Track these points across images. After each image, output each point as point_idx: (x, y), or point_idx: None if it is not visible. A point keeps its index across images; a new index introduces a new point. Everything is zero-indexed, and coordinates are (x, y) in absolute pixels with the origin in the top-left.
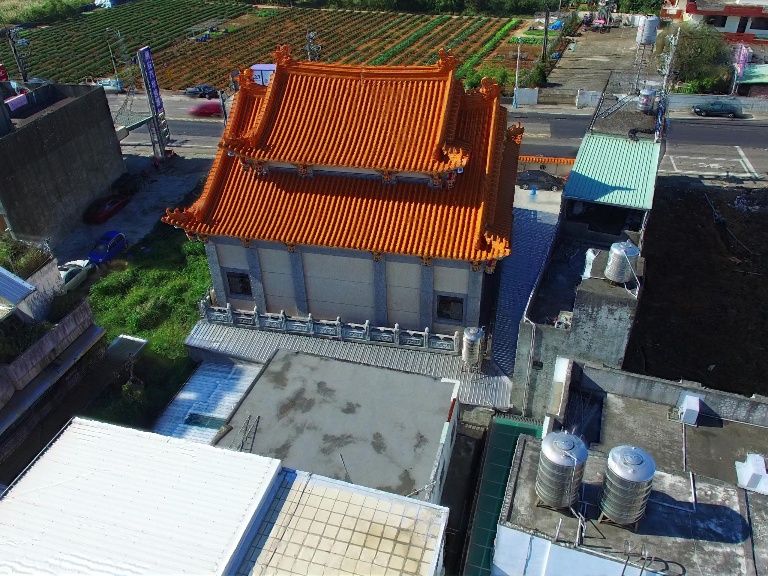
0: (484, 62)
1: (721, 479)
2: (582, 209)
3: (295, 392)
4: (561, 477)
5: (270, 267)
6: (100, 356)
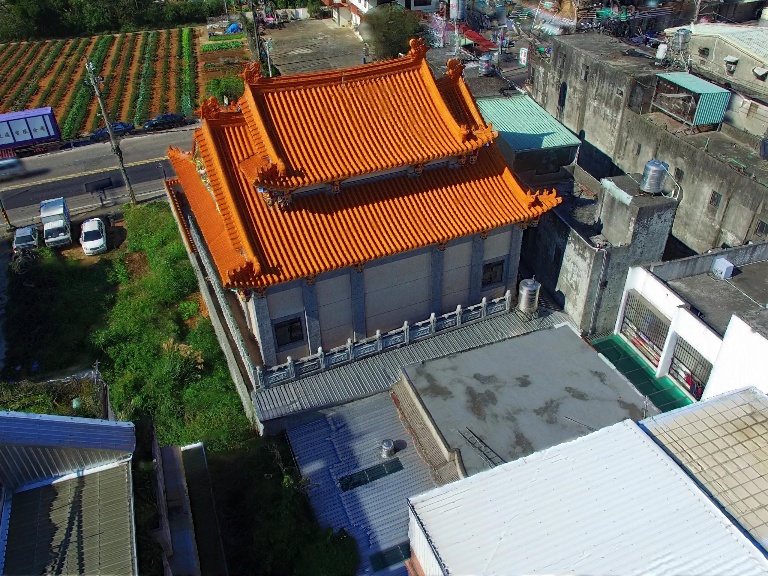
0: None
1: None
2: None
3: (466, 393)
4: None
5: (326, 299)
6: None
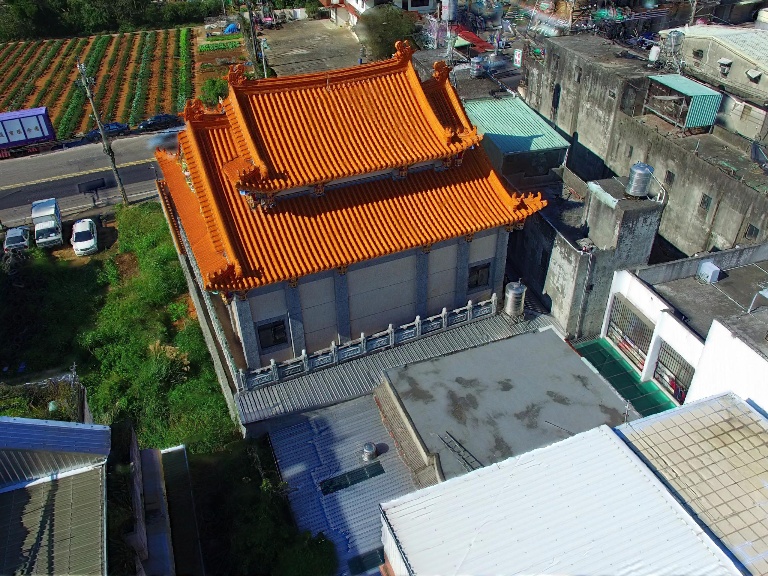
0: None
1: None
2: None
3: (448, 397)
4: None
5: (310, 302)
6: None
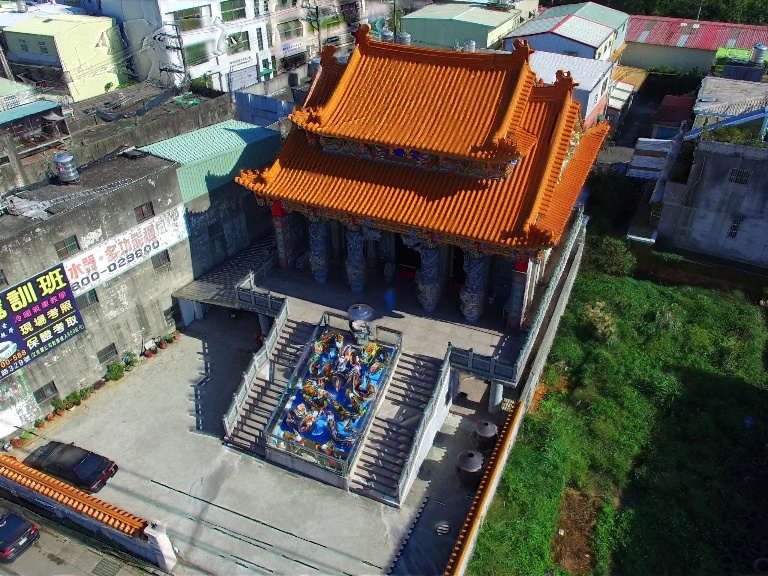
0: None
1: None
2: None
3: None
4: None
5: None
6: None
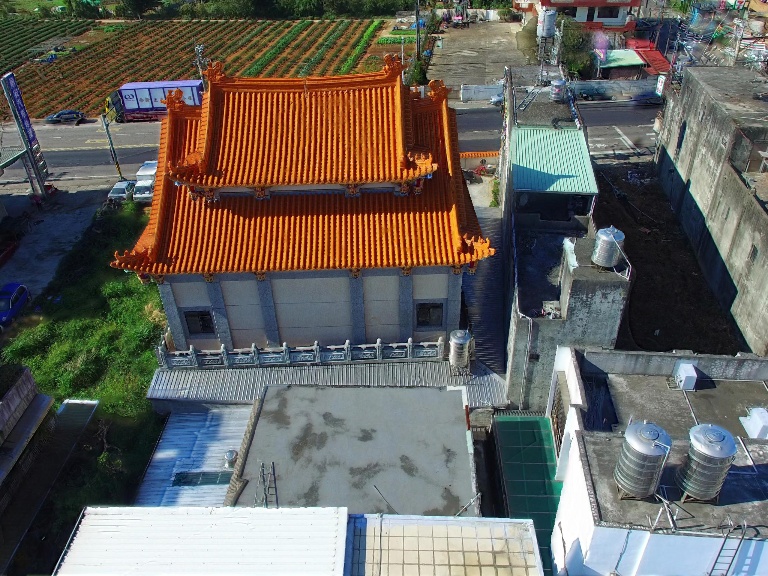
0: (361, 64)
1: (734, 436)
2: (527, 200)
3: (302, 429)
4: (651, 467)
5: (235, 300)
6: (50, 429)
